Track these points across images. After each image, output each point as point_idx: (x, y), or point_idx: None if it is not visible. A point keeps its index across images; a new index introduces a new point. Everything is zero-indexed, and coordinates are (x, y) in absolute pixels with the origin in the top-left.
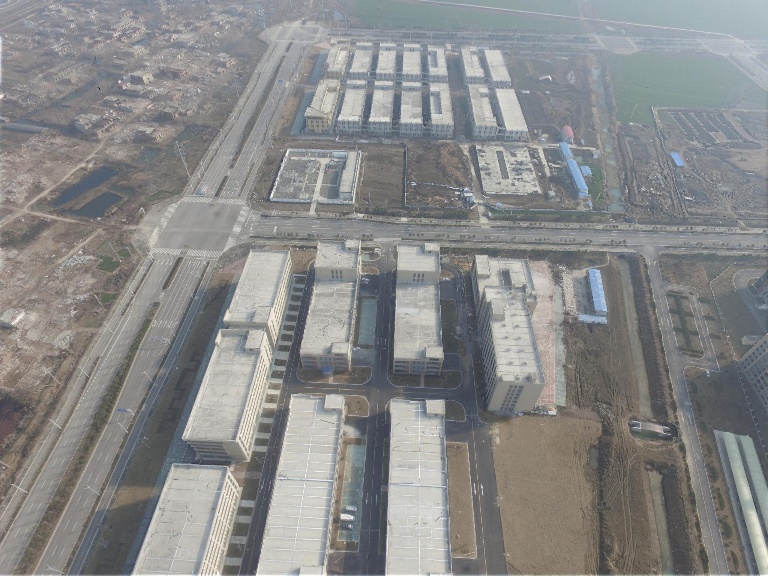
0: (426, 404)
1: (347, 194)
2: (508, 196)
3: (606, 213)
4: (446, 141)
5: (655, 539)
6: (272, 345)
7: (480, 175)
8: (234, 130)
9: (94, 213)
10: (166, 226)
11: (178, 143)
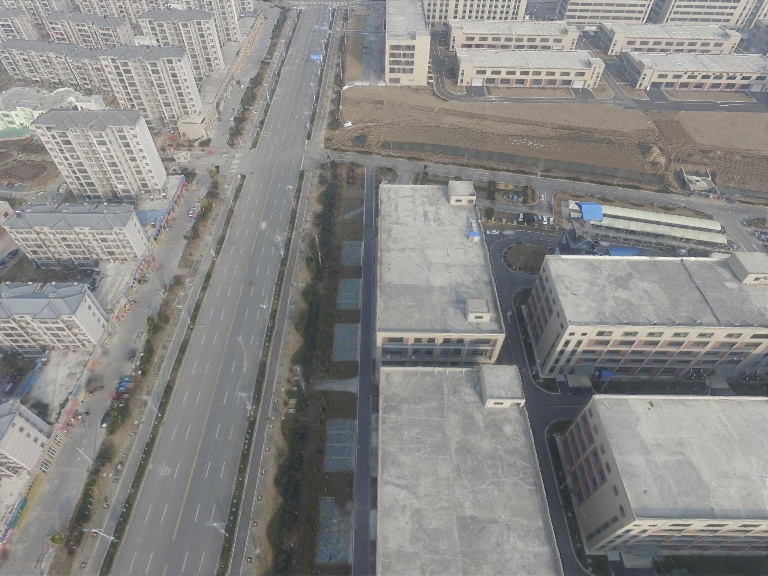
0: None
1: None
2: None
3: None
4: None
5: (766, 188)
6: (750, 24)
7: None
8: None
9: None
10: None
11: None
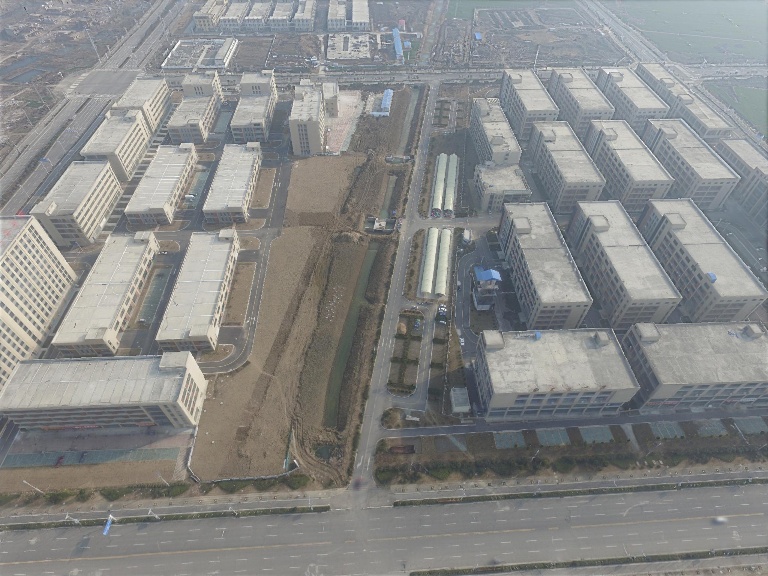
0: (247, 144)
1: (221, 61)
2: (344, 60)
3: (413, 66)
4: (307, 33)
5: (381, 199)
6: (151, 130)
7: (327, 50)
8: (138, 32)
9: (23, 80)
10: (79, 84)
11: (86, 27)
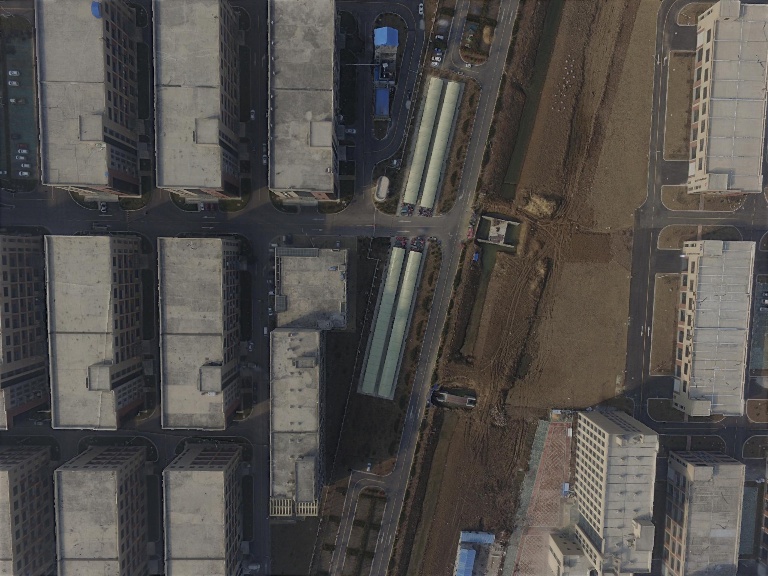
0: None
1: None
2: None
3: None
4: None
5: (491, 295)
6: None
7: None
8: None
9: None
10: None
11: None
